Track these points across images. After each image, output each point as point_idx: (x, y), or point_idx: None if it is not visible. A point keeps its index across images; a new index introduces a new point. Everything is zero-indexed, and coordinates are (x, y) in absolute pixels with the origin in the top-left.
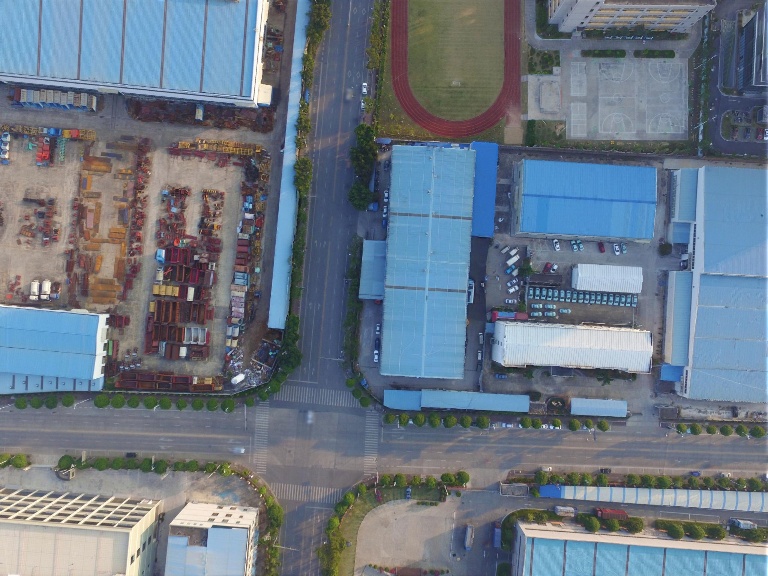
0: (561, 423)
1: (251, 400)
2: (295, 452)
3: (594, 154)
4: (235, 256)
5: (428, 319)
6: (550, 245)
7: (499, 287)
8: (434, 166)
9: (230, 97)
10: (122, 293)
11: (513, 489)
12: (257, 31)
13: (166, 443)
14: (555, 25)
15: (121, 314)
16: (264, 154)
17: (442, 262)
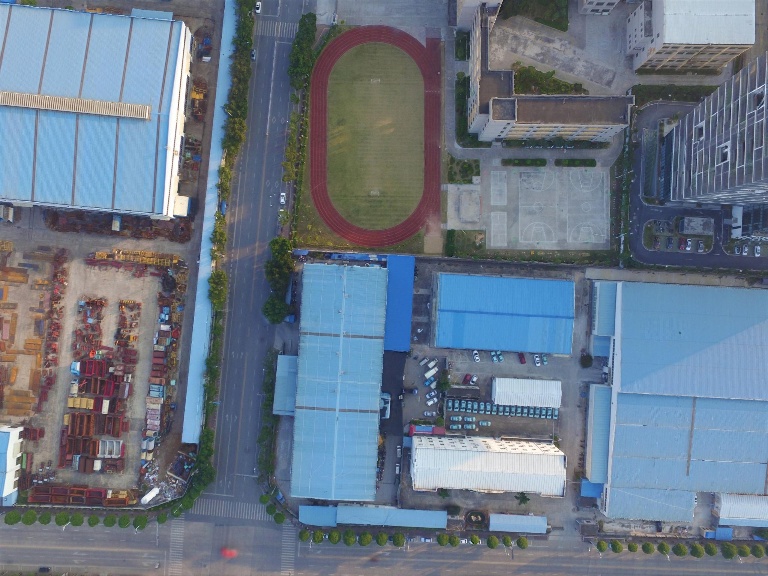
0: (481, 538)
1: (163, 517)
2: (210, 567)
3: (514, 264)
4: (151, 368)
5: (338, 441)
6: (470, 356)
7: (418, 399)
8: (345, 285)
9: (143, 213)
10: (37, 405)
11: None
12: (169, 149)
13: (80, 557)
14: (475, 134)
15: (36, 426)
16: (181, 264)
17: (353, 382)
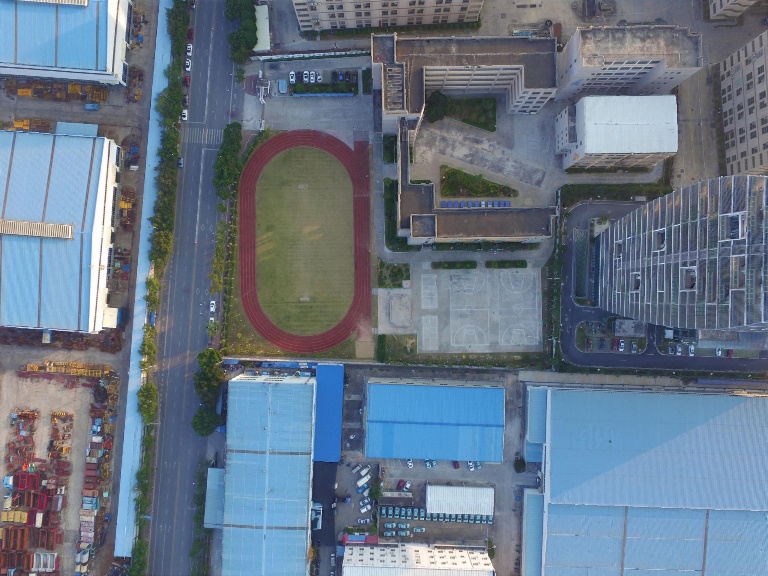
0: None
1: None
2: None
3: (446, 368)
4: (83, 480)
5: (266, 558)
6: (403, 461)
7: (352, 506)
8: (270, 402)
9: None
10: None
11: None
12: (93, 267)
13: None
14: (404, 238)
15: None
16: (113, 375)
17: (280, 500)
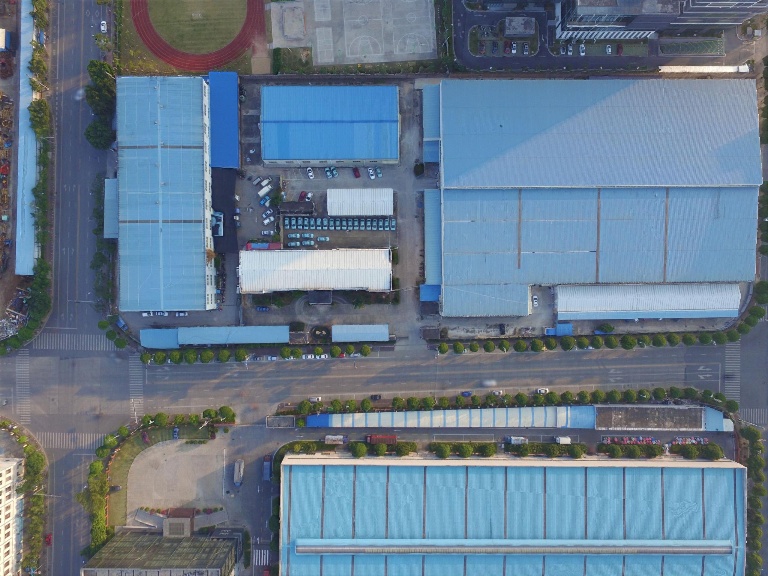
0: (327, 352)
1: (2, 349)
2: (59, 400)
3: (343, 79)
4: None
5: (164, 252)
6: (304, 174)
7: (255, 219)
8: (159, 96)
9: None
10: None
11: (279, 421)
12: None
13: None
14: None
15: None
16: (5, 100)
17: (175, 193)
